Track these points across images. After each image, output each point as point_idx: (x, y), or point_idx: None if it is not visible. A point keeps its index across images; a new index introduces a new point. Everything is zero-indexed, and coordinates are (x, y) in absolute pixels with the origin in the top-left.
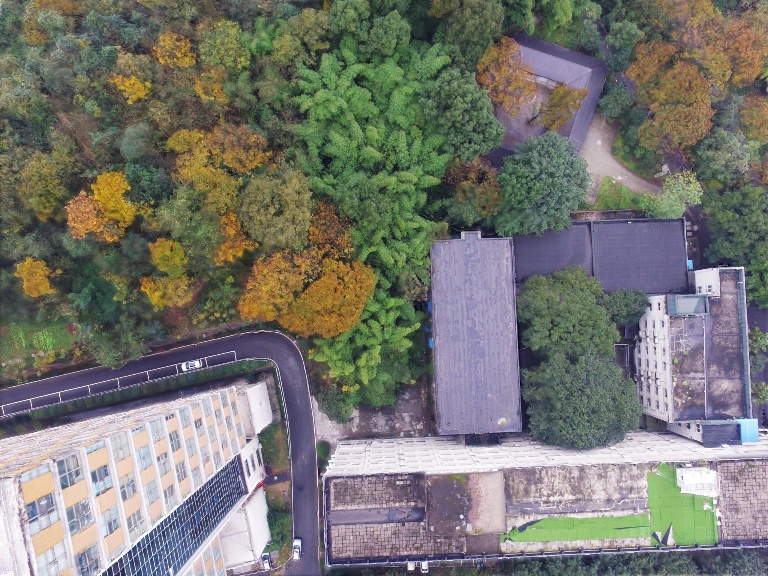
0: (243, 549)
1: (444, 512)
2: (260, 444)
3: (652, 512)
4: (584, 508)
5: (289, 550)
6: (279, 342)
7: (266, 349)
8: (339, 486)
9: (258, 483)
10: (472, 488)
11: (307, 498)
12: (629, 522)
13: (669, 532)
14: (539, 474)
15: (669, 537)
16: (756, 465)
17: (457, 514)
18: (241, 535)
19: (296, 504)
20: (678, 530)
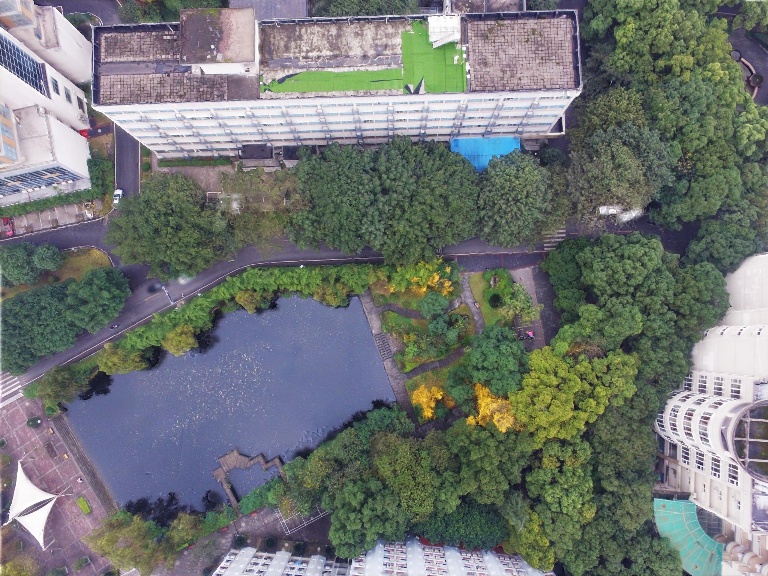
0: (44, 151)
1: (196, 43)
2: (85, 99)
3: (405, 66)
4: (341, 64)
5: (111, 201)
6: (104, 0)
7: (91, 6)
8: (109, 40)
9: (82, 135)
10: (223, 22)
11: (129, 150)
12: (383, 75)
13: (421, 84)
14: (299, 32)
15: (421, 89)
16: (505, 24)
17: (208, 45)
18: (42, 138)
19: (119, 157)
20: (429, 83)
